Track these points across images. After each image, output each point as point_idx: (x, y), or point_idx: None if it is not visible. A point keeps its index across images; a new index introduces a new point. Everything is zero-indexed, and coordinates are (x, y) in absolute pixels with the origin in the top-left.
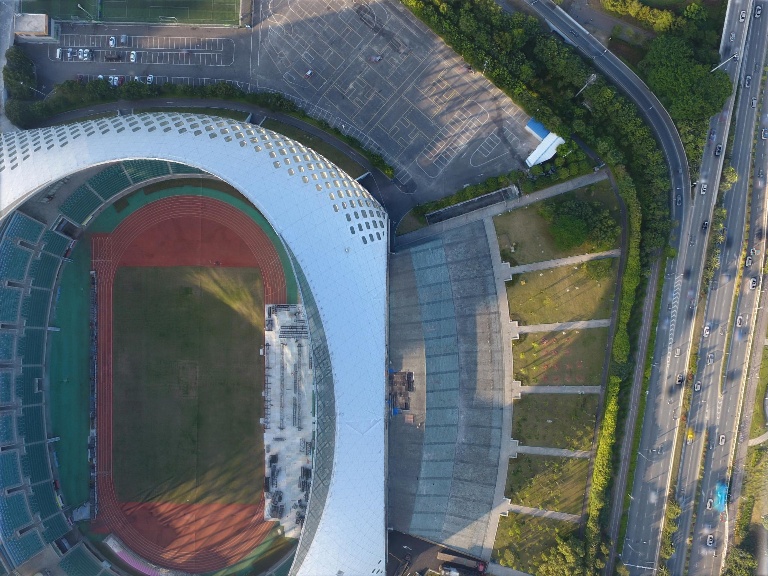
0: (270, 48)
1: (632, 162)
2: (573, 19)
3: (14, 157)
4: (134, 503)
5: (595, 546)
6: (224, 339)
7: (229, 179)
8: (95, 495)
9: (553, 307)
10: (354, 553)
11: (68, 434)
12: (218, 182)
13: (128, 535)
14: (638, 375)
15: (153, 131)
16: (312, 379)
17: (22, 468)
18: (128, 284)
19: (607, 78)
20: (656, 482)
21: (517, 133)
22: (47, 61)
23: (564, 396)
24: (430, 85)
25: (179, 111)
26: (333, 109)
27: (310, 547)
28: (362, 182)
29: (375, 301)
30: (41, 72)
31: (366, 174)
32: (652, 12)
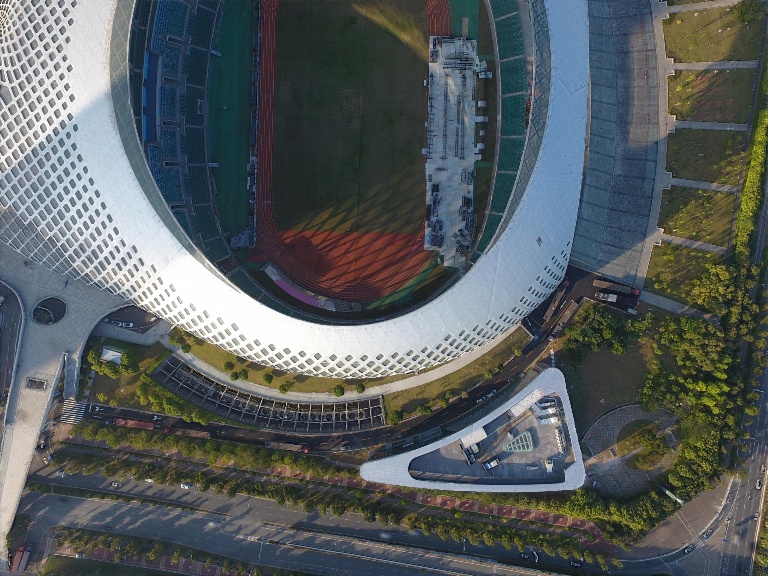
0: None
1: None
2: None
3: None
4: (293, 232)
5: (746, 267)
6: (388, 69)
7: None
8: (254, 222)
9: (706, 46)
10: (553, 221)
11: (227, 162)
12: None
13: (286, 264)
14: None
15: None
16: (474, 111)
17: (184, 187)
18: (292, 12)
19: None
20: None
21: None
22: None
23: None
24: None
25: None
26: None
27: (521, 200)
28: None
29: None
30: None
31: None
32: None
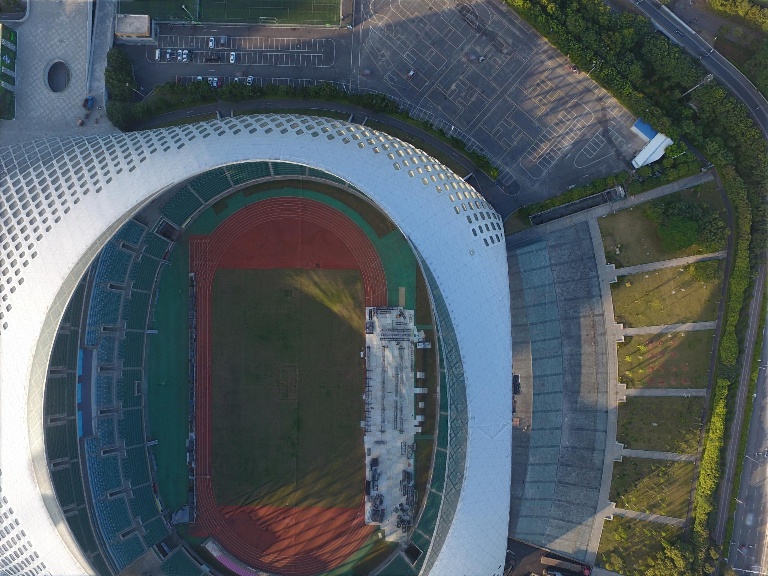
0: (371, 49)
1: (739, 163)
2: (679, 19)
3: (130, 159)
4: (233, 507)
5: (704, 550)
6: (324, 342)
7: (354, 181)
8: (194, 498)
9: (658, 309)
10: (479, 558)
11: (166, 437)
12: (318, 184)
13: (227, 539)
14: (744, 378)
15: (270, 133)
16: (413, 382)
17: (123, 471)
18: (227, 286)
19: None
20: (762, 486)
21: (622, 134)
22: (145, 62)
23: (669, 399)
24: (534, 86)
25: (280, 112)
26: (435, 110)
27: (440, 552)
28: None
29: (500, 304)
30: (139, 73)
31: (469, 175)
32: (762, 11)
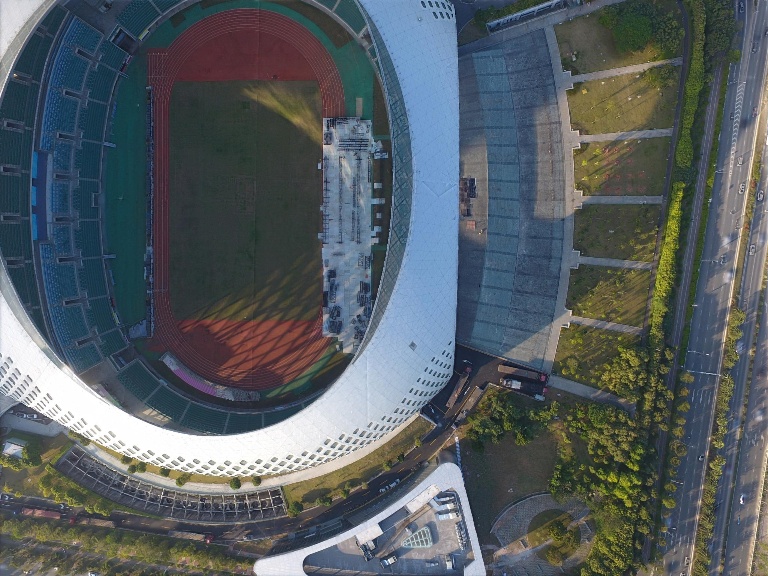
0: None
1: None
2: None
3: None
4: (191, 321)
5: (659, 351)
6: (282, 154)
7: None
8: (151, 312)
9: (615, 116)
10: (427, 325)
11: (124, 252)
12: None
13: (184, 353)
14: (700, 185)
15: None
16: (371, 193)
17: (79, 281)
18: (185, 99)
19: None
20: (718, 293)
21: None
22: None
23: (626, 206)
24: None
25: None
26: None
27: (386, 309)
28: None
29: (448, 70)
30: None
31: None
32: None
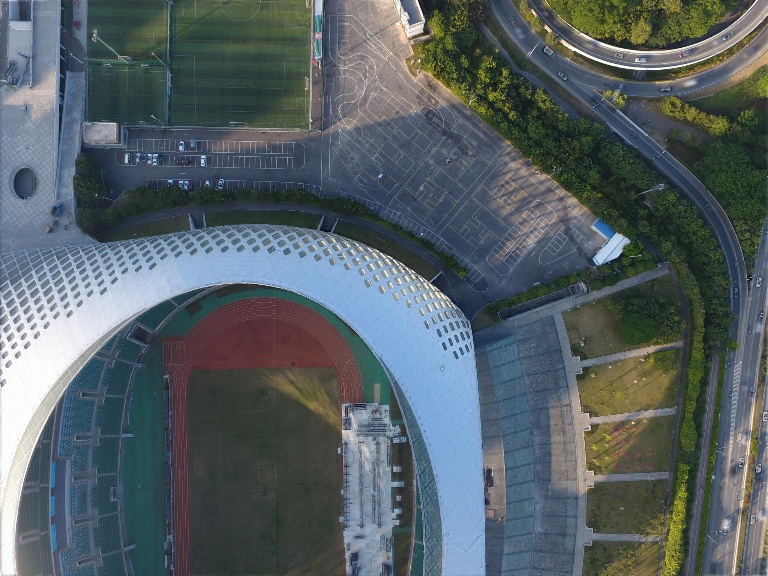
0: (341, 151)
1: (692, 258)
2: (633, 122)
3: (101, 280)
4: None
5: None
6: (301, 439)
7: (326, 303)
8: None
9: (622, 398)
10: None
11: (144, 541)
12: None
13: None
14: (703, 460)
15: (242, 251)
16: (390, 476)
17: None
18: (202, 387)
19: (666, 178)
20: (723, 562)
21: (583, 232)
22: (115, 166)
23: (635, 483)
24: (498, 186)
25: (252, 215)
26: (405, 211)
27: None
28: (436, 282)
29: (471, 417)
30: (109, 177)
31: (439, 274)
32: (708, 117)
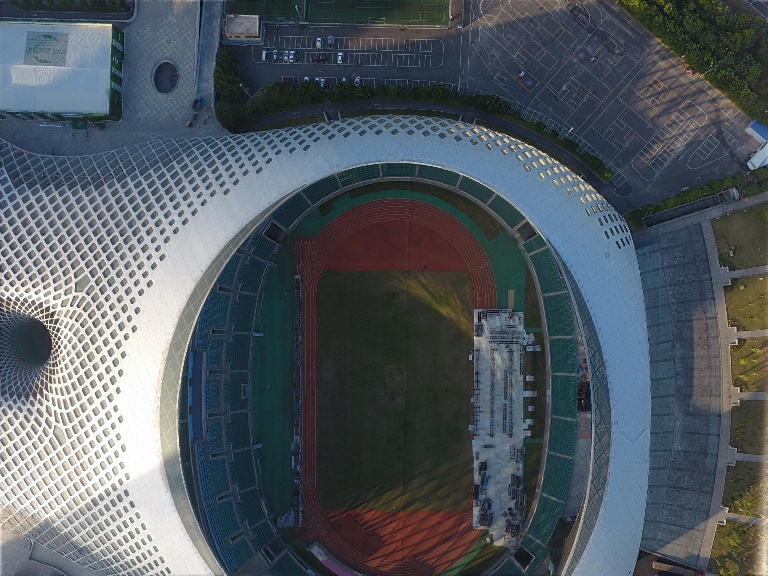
0: (481, 49)
1: None
2: None
3: (255, 161)
4: (339, 511)
5: None
6: (432, 344)
7: (490, 183)
8: (300, 502)
9: None
10: (614, 564)
11: (271, 441)
12: (426, 185)
13: (332, 543)
14: None
15: (397, 134)
16: (522, 385)
17: (230, 475)
18: (333, 289)
19: None
20: None
21: (736, 135)
22: (251, 63)
23: None
24: (646, 86)
25: (388, 113)
26: (546, 111)
27: (581, 558)
28: None
29: (637, 307)
30: (245, 74)
31: (581, 177)
32: None
